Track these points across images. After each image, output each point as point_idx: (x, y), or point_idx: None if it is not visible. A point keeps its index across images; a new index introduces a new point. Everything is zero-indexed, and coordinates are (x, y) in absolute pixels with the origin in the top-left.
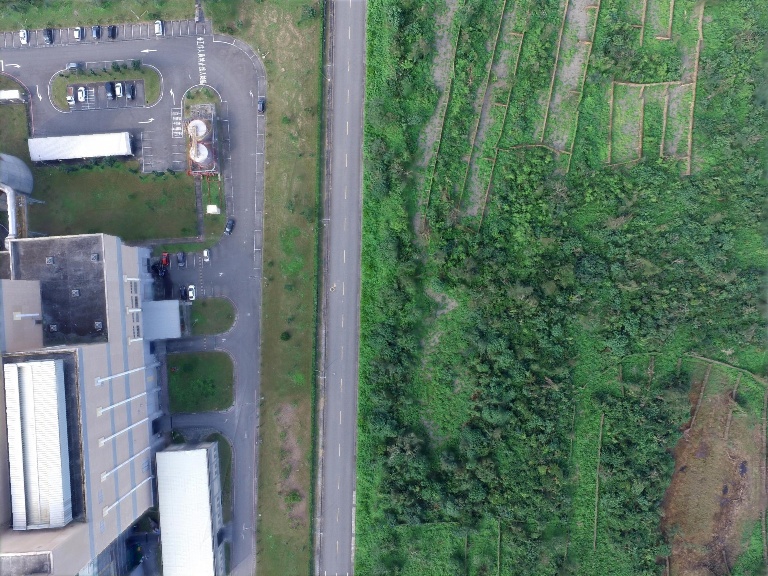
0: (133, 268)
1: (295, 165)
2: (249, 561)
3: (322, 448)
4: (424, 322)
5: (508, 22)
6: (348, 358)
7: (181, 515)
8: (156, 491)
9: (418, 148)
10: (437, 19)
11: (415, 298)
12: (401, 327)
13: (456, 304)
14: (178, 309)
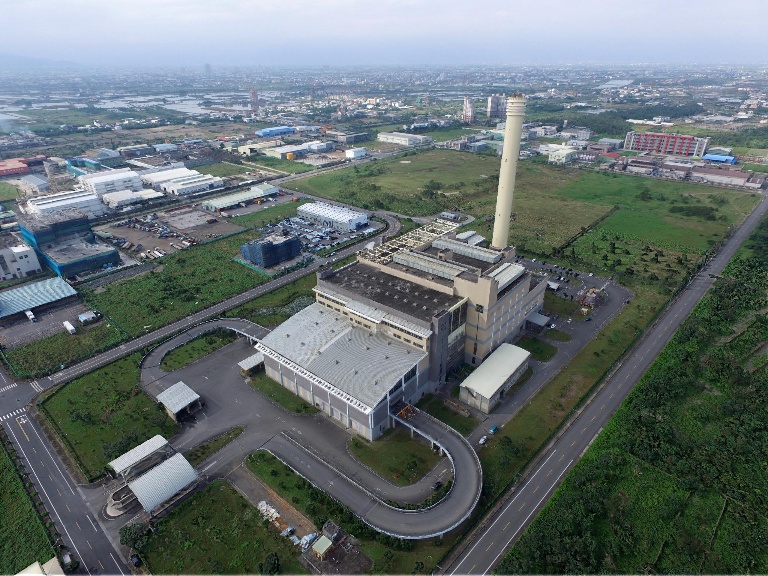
0: (539, 301)
1: None
2: (507, 416)
3: (591, 400)
4: (694, 383)
5: None
6: (630, 380)
7: (499, 363)
8: None
9: (714, 339)
10: (740, 318)
11: None
12: None
13: (720, 394)
14: (548, 320)
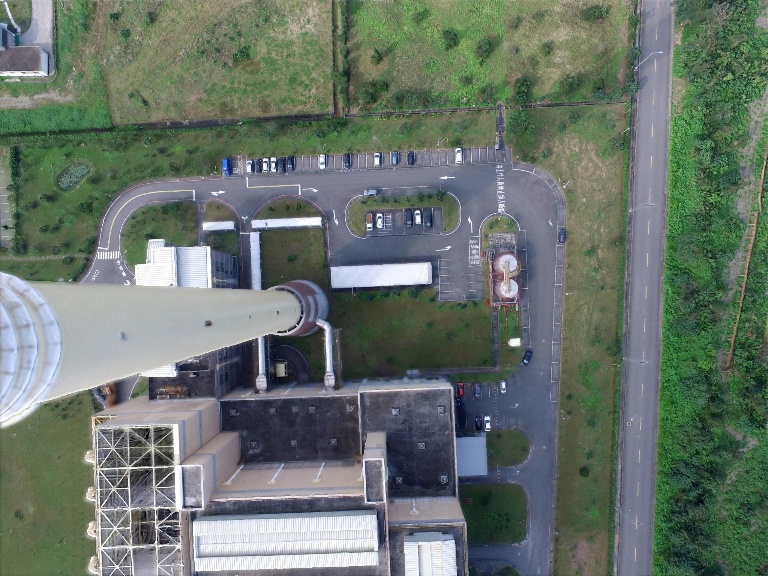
0: None
1: (595, 297)
2: None
3: None
4: (731, 464)
5: None
6: (644, 494)
7: None
8: None
9: (722, 283)
10: (740, 149)
11: (717, 437)
12: (703, 466)
13: (757, 443)
14: (485, 446)
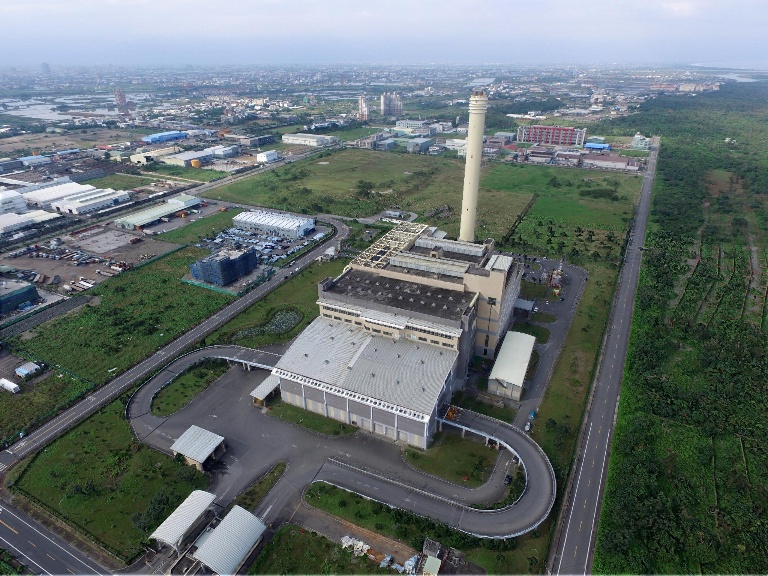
0: None
1: (599, 293)
2: (537, 400)
3: (599, 373)
4: (672, 343)
5: (713, 292)
6: (620, 348)
7: None
8: (500, 344)
9: None
10: (675, 282)
11: None
12: None
13: (692, 349)
14: None
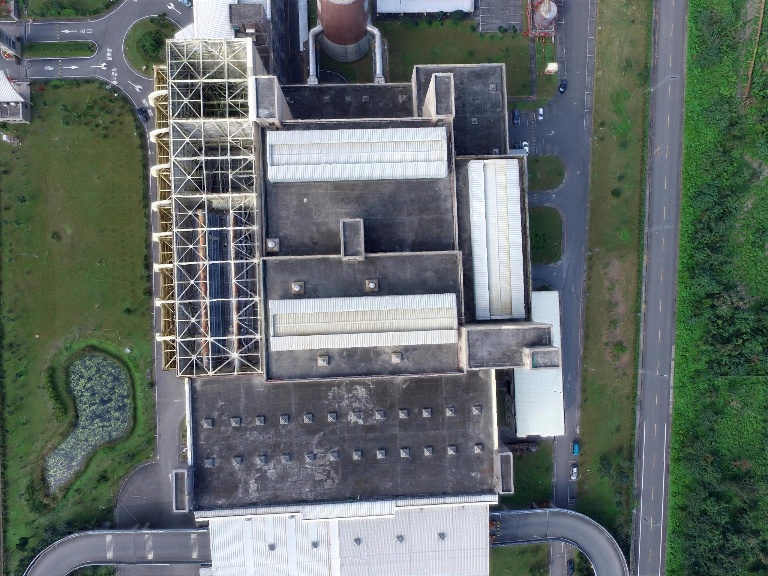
0: None
1: (626, 31)
2: (574, 410)
3: (644, 303)
4: (750, 183)
5: None
6: (670, 218)
7: None
8: None
9: None
10: None
11: (737, 162)
12: (723, 189)
13: None
14: None
